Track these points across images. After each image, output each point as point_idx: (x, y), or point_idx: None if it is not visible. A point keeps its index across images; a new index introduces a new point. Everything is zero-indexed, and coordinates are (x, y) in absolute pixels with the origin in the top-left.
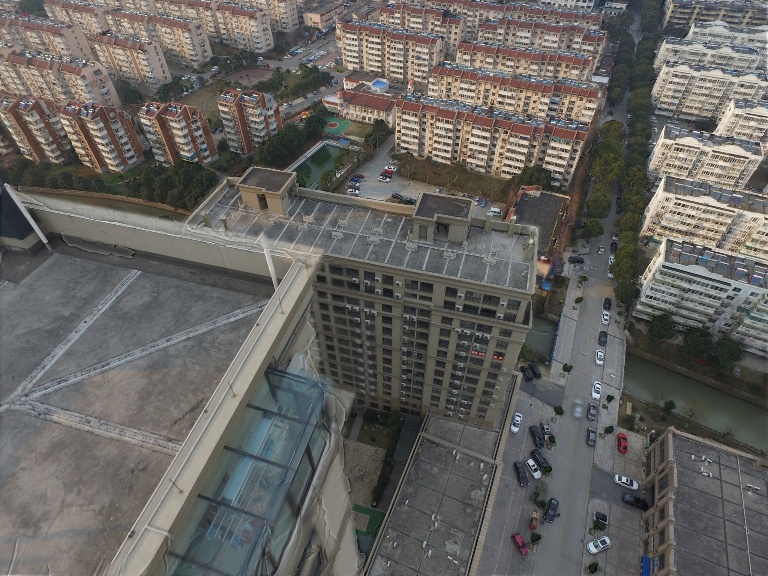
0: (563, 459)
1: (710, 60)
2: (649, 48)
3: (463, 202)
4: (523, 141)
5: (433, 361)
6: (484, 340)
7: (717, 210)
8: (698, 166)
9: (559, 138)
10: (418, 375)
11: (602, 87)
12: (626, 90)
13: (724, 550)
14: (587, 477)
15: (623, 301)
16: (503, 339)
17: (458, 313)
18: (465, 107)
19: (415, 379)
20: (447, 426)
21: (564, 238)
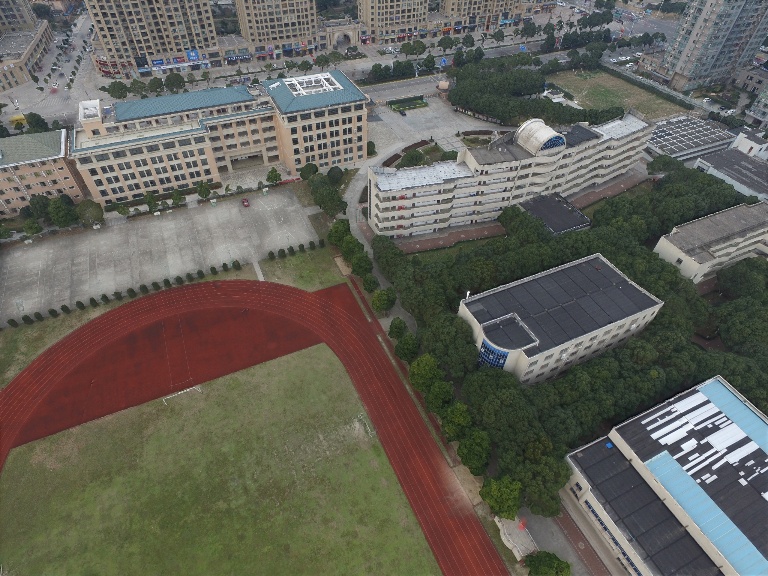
0: (78, 43)
1: None
2: None
3: None
4: None
5: None
6: None
7: None
8: None
9: None
10: None
11: None
12: None
13: None
14: None
15: None
16: None
17: None
18: None
19: None
20: None
21: (75, 3)
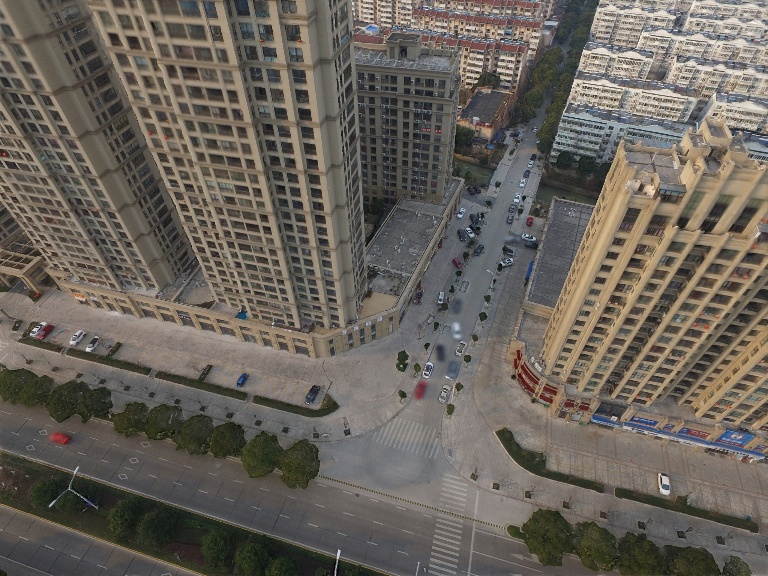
0: (490, 230)
1: (638, 5)
2: (594, 0)
3: (416, 36)
4: (479, 55)
5: (401, 143)
6: (429, 117)
7: (611, 89)
8: (610, 70)
9: (506, 52)
10: (393, 161)
11: (552, 28)
12: (571, 30)
13: (573, 244)
14: (504, 237)
15: (542, 151)
16: (439, 113)
17: (412, 95)
18: (437, 34)
19: (391, 165)
20: (413, 204)
21: (507, 121)
